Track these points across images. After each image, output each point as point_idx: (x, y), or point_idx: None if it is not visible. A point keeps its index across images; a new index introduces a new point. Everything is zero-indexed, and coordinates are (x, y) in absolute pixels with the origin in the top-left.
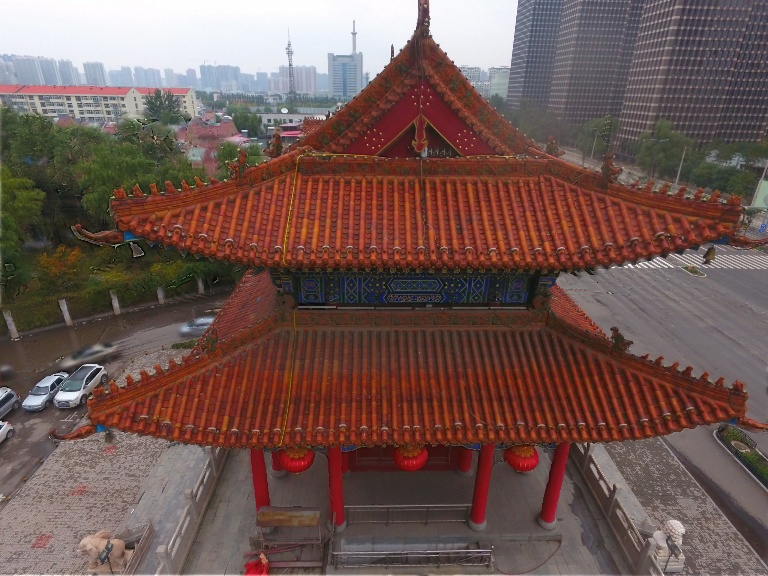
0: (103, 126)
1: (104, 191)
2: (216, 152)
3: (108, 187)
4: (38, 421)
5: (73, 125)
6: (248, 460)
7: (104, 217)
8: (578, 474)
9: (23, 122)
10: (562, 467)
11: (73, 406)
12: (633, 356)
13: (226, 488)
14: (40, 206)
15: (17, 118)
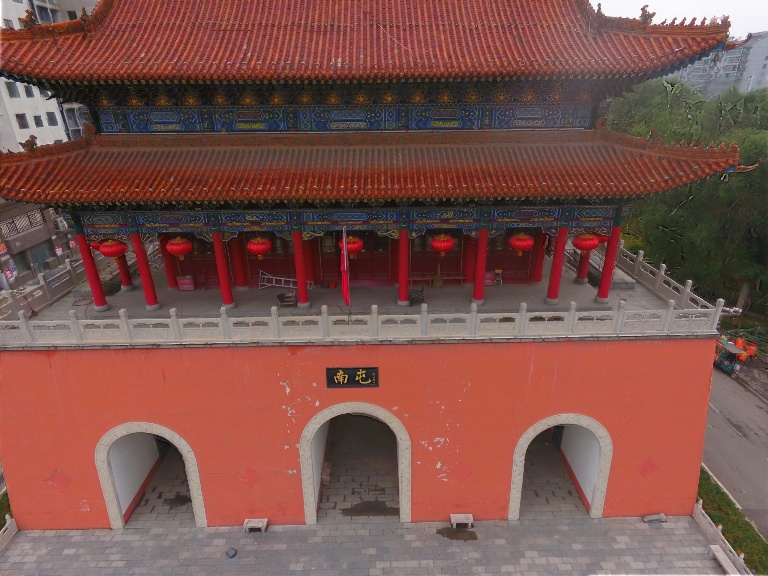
0: (673, 92)
1: None
2: None
3: None
4: None
5: None
6: None
7: None
8: None
9: None
10: None
11: None
12: (19, 152)
13: None
14: None
15: None
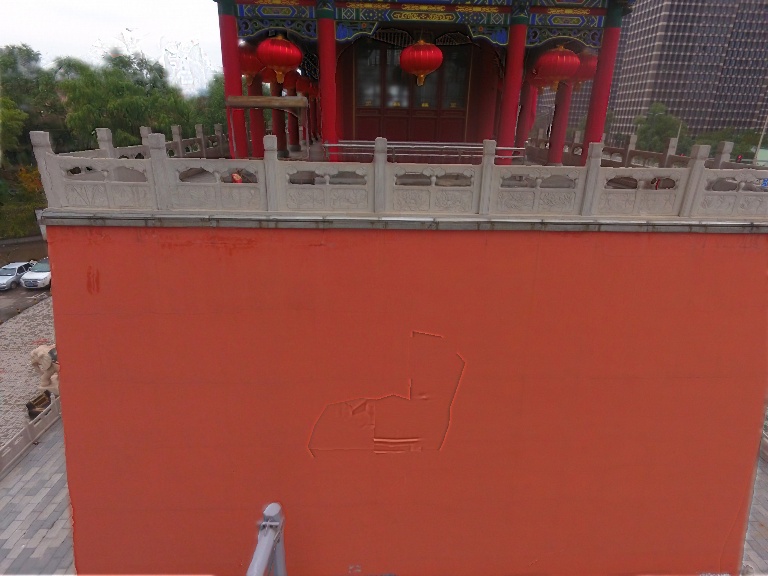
0: None
1: (89, 110)
2: (208, 84)
3: (93, 106)
4: (1, 297)
5: (61, 58)
6: (224, 173)
7: (89, 141)
8: (616, 184)
9: (9, 53)
10: (608, 73)
11: (41, 286)
12: None
13: (196, 179)
14: (21, 126)
15: (3, 49)
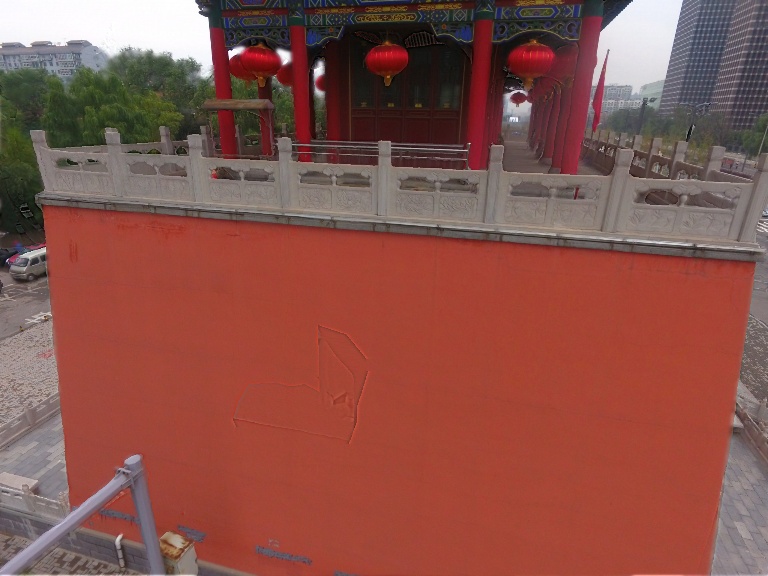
0: None
1: None
2: None
3: None
4: None
5: None
6: None
7: None
8: None
9: (179, 65)
10: (587, 68)
11: None
12: None
13: None
14: (178, 126)
15: (175, 62)
